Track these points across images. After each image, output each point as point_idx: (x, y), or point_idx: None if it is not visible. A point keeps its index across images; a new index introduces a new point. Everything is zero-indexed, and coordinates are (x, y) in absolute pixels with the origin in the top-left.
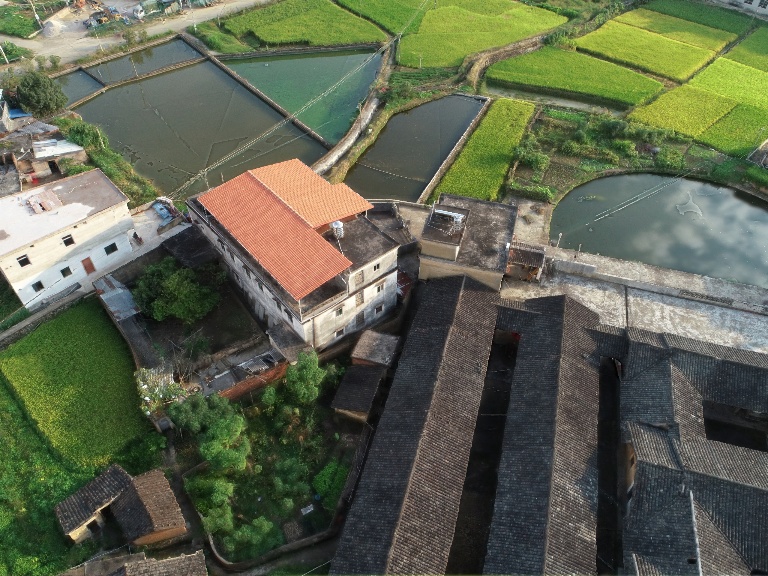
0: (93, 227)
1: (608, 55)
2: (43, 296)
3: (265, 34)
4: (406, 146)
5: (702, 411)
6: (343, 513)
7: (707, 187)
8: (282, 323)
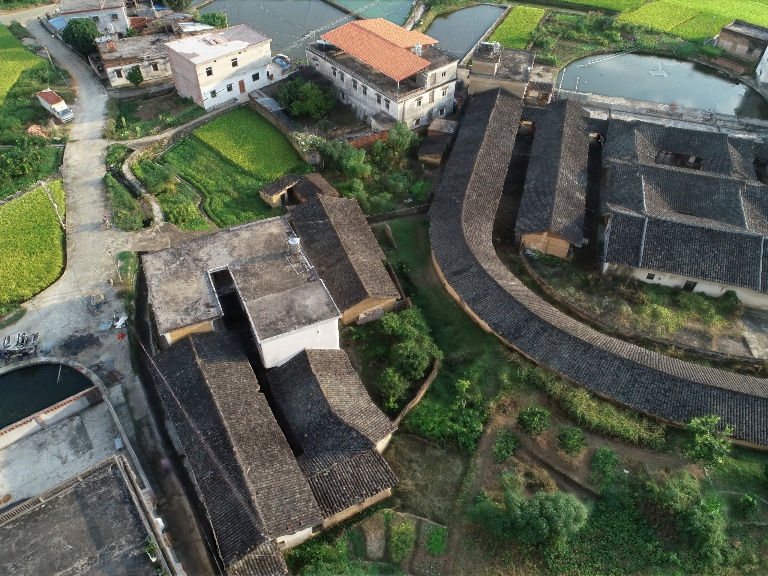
0: (249, 56)
1: None
2: (215, 103)
3: None
4: (449, 33)
5: (654, 154)
6: (430, 202)
7: (673, 62)
8: (380, 113)
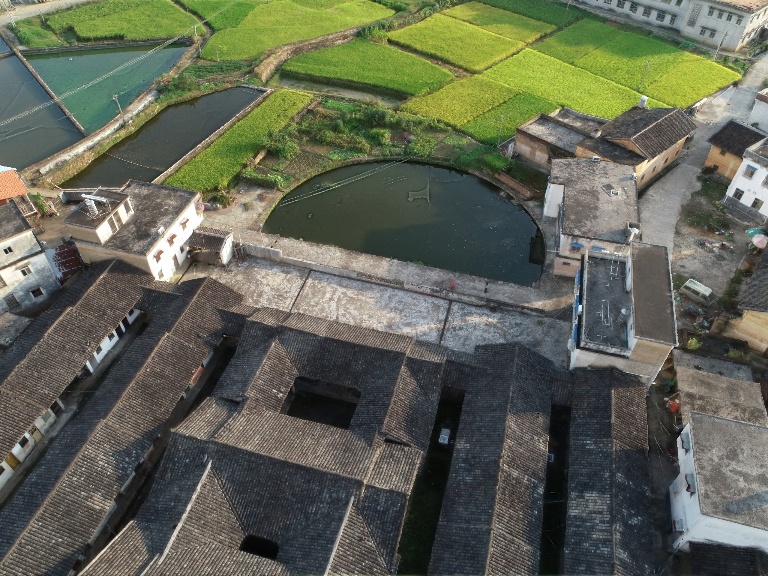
0: None
1: (416, 47)
2: None
3: (83, 29)
4: None
5: (290, 386)
6: None
7: (453, 174)
8: None
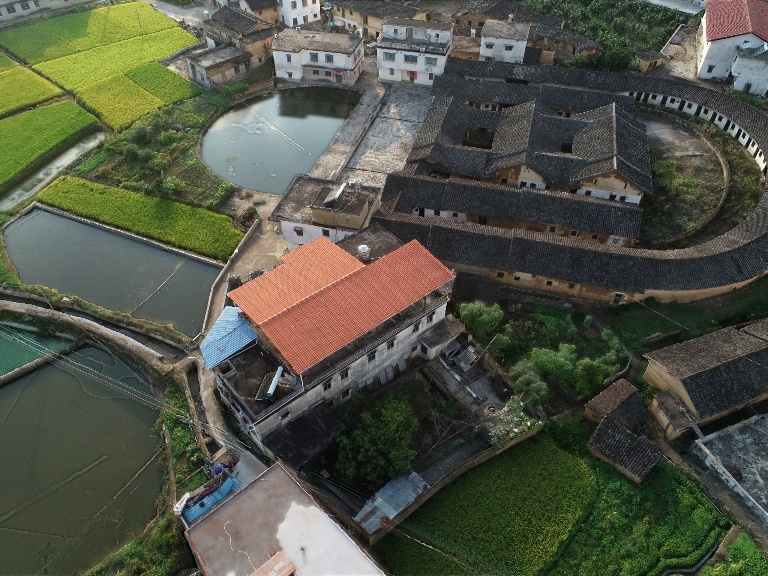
0: None
1: None
2: None
3: None
4: (106, 274)
5: None
6: None
7: (226, 117)
8: (422, 338)
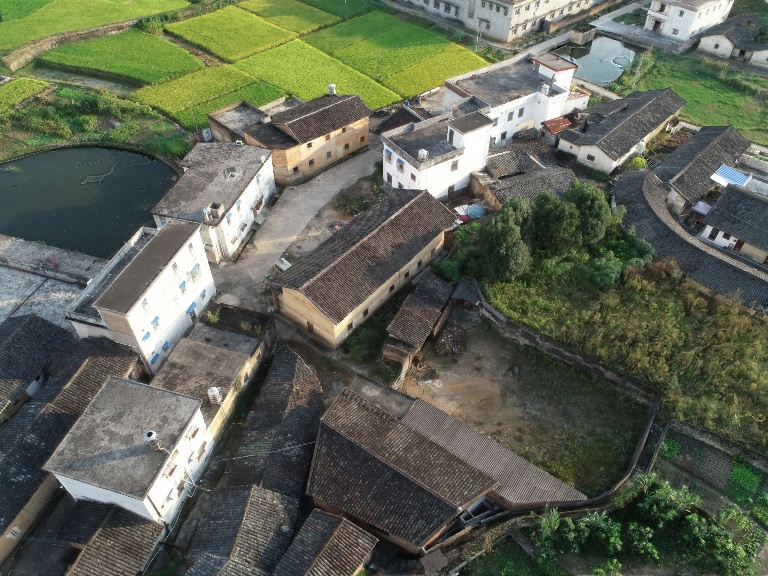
0: None
1: (186, 38)
2: None
3: None
4: None
5: None
6: None
7: (146, 159)
8: None
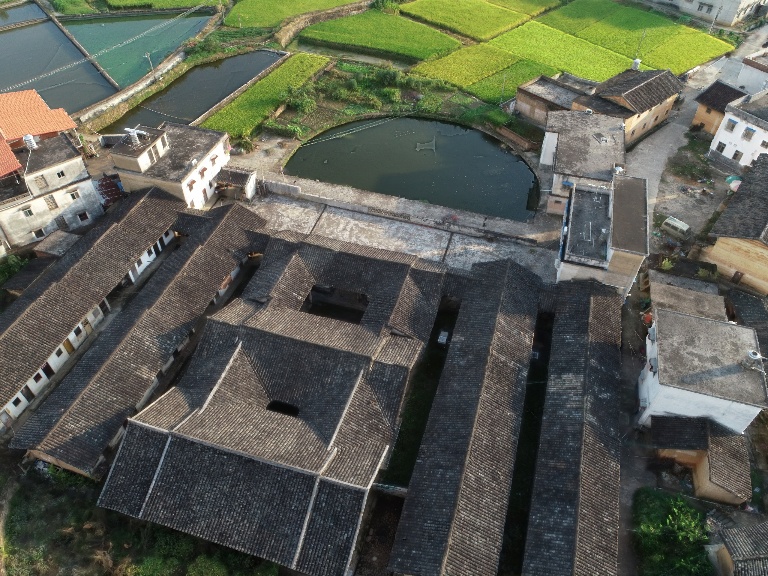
0: None
1: (426, 18)
2: None
3: None
4: (191, 92)
5: (308, 292)
6: None
7: (457, 129)
8: None
